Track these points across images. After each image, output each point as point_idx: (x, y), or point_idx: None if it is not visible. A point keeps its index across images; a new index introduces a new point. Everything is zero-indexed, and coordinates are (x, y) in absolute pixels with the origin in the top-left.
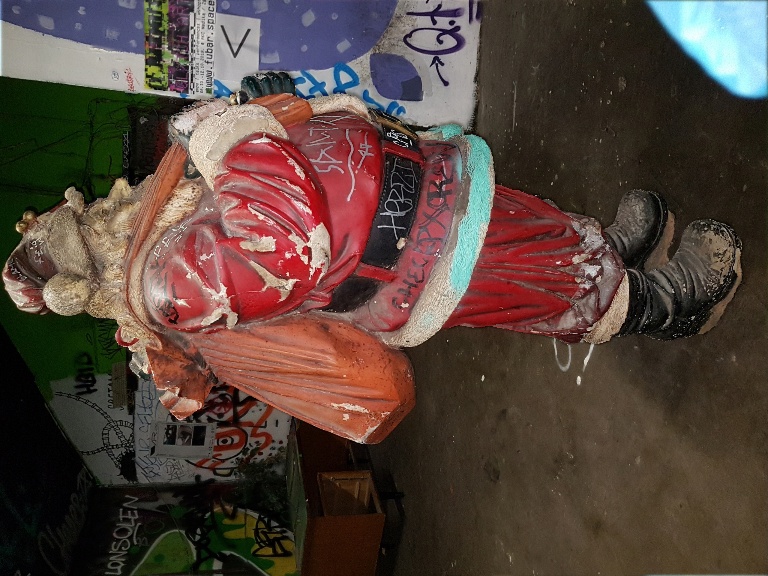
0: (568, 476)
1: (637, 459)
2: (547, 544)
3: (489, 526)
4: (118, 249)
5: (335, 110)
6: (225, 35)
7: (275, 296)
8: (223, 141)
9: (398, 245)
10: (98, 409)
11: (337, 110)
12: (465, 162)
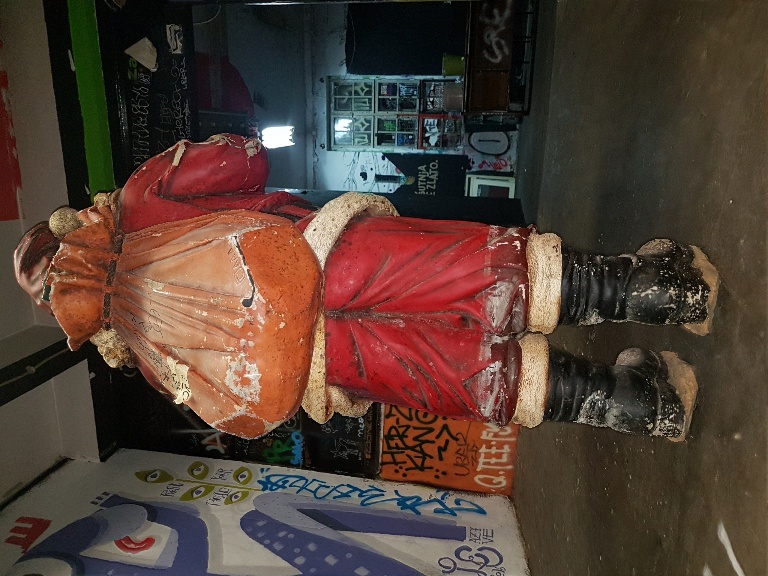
0: None
1: None
2: None
3: None
4: None
5: None
6: None
7: None
8: None
9: None
10: None
11: None
12: None
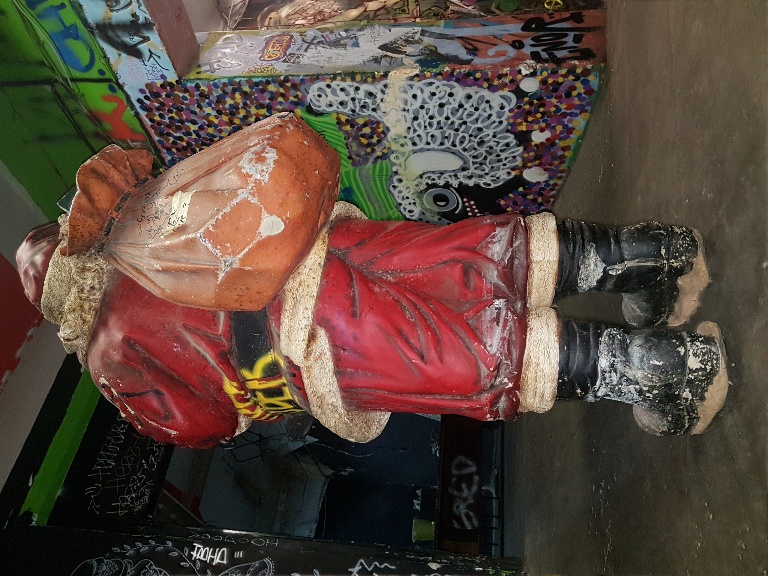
0: None
1: None
2: None
3: None
4: None
5: None
6: None
7: None
8: None
9: None
10: None
11: None
12: None
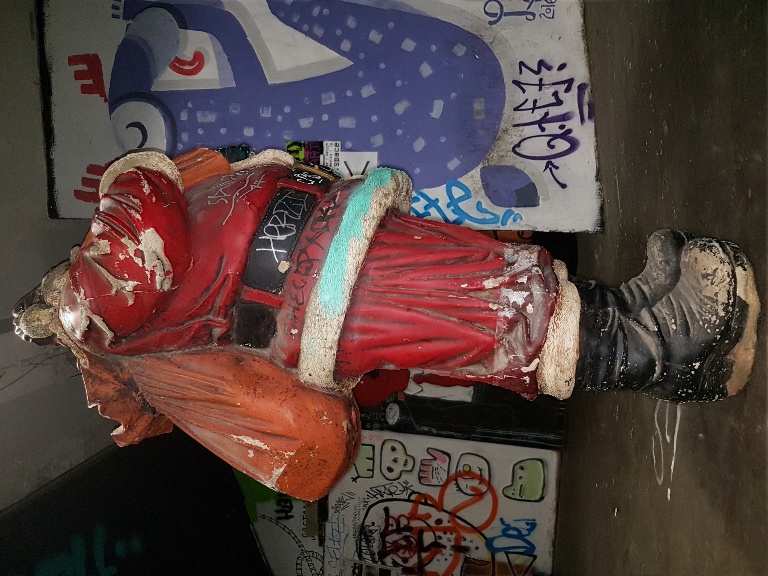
0: None
1: None
2: None
3: None
4: (60, 278)
5: None
6: (348, 169)
7: (124, 299)
8: (112, 177)
9: (281, 268)
10: (294, 536)
11: None
12: None
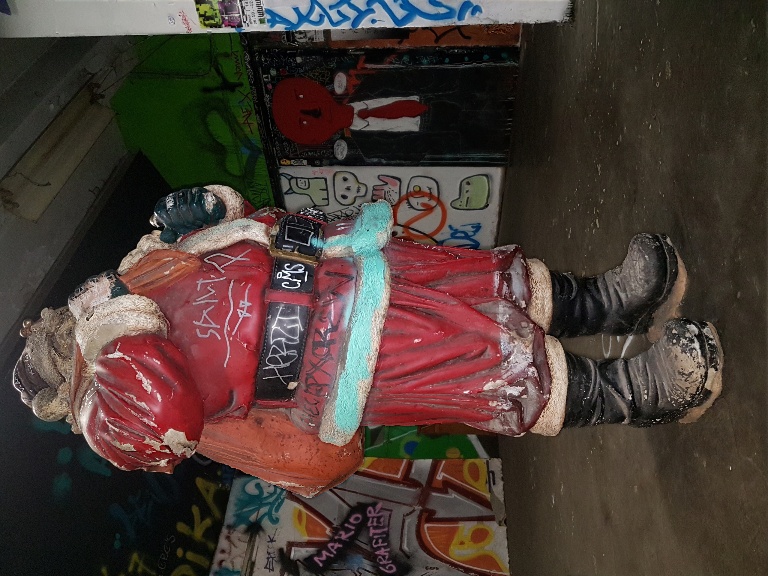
0: (597, 457)
1: (635, 487)
2: (580, 500)
3: (553, 449)
4: (62, 393)
5: (234, 242)
6: None
7: None
8: (91, 347)
9: (290, 387)
10: None
11: (236, 241)
12: (355, 304)
